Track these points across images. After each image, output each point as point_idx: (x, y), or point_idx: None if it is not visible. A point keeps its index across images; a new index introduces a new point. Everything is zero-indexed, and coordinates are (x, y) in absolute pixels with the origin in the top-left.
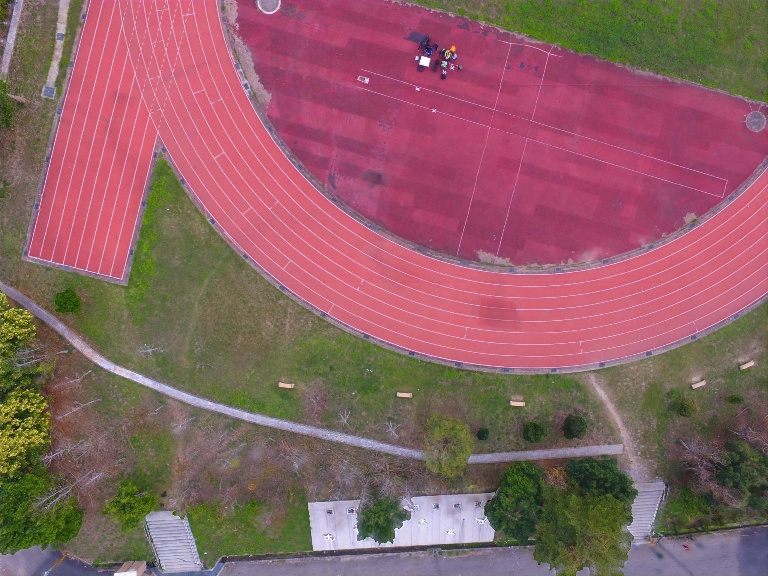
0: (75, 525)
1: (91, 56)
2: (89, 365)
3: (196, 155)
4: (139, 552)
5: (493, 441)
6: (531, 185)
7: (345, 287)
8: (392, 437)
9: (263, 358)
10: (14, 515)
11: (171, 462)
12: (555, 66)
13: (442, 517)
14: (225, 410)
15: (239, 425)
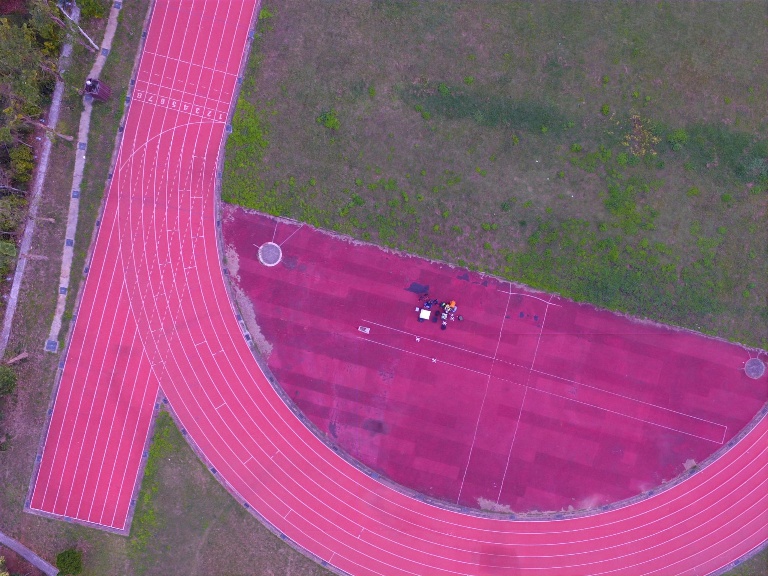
0: None
1: (94, 310)
2: None
3: (197, 406)
4: None
5: None
6: (531, 433)
7: (346, 535)
8: None
9: None
10: None
11: None
12: (554, 315)
13: None
14: None
15: None
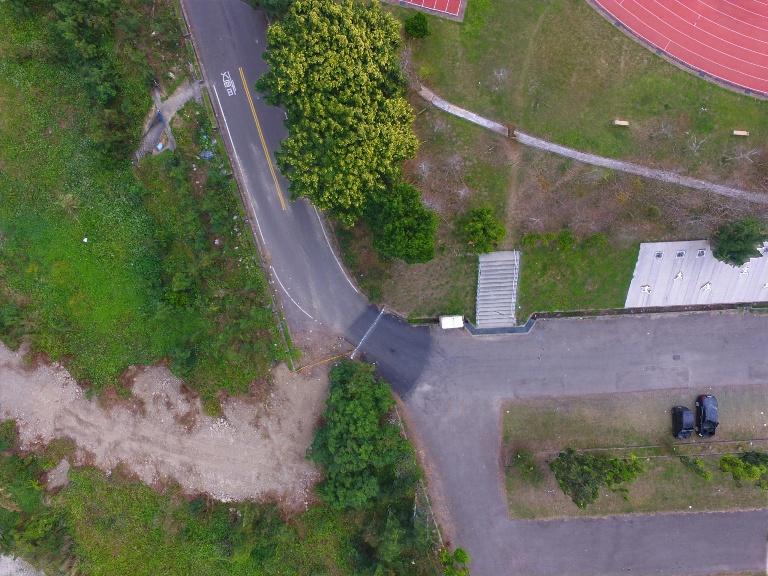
0: None
1: None
2: (423, 104)
3: None
4: (456, 305)
5: None
6: None
7: (682, 23)
8: (726, 178)
9: (597, 96)
10: (409, 208)
11: (504, 202)
12: None
13: (766, 265)
14: (559, 149)
15: (573, 165)
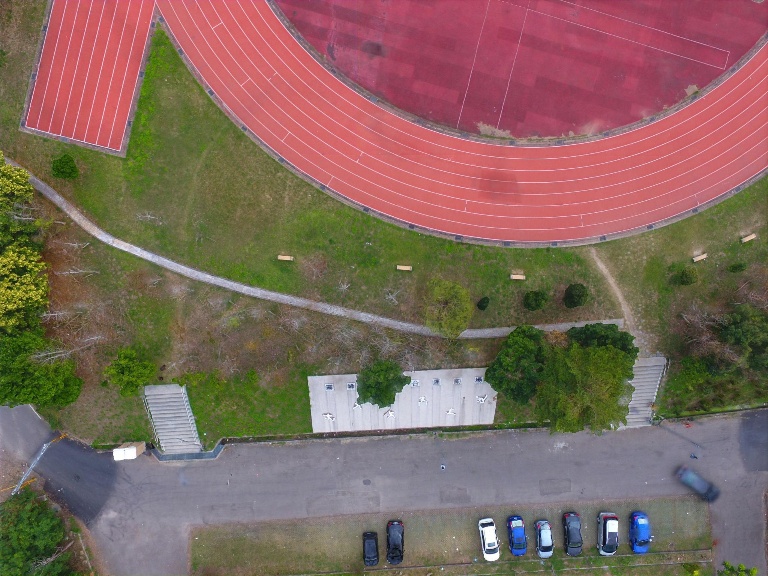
0: (74, 389)
1: None
2: (87, 238)
3: (194, 25)
4: (138, 432)
5: (493, 316)
6: (532, 56)
7: (344, 159)
8: (392, 311)
9: (262, 231)
10: (12, 365)
11: (170, 335)
12: None
13: (442, 395)
14: (224, 283)
15: (238, 298)
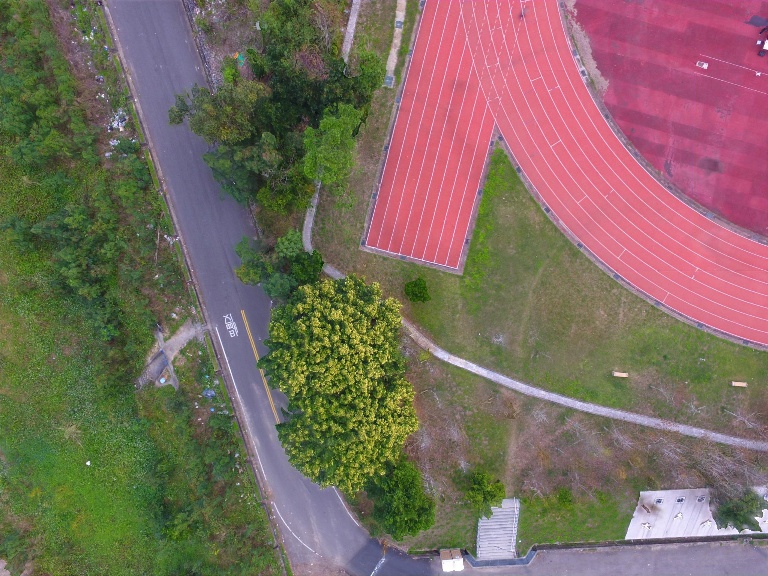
0: (433, 512)
1: (430, 44)
2: None
3: (533, 143)
4: (456, 540)
5: None
6: None
7: (680, 276)
8: (725, 426)
9: (596, 347)
10: (410, 502)
11: (504, 451)
12: None
13: None
14: (558, 399)
15: (572, 414)
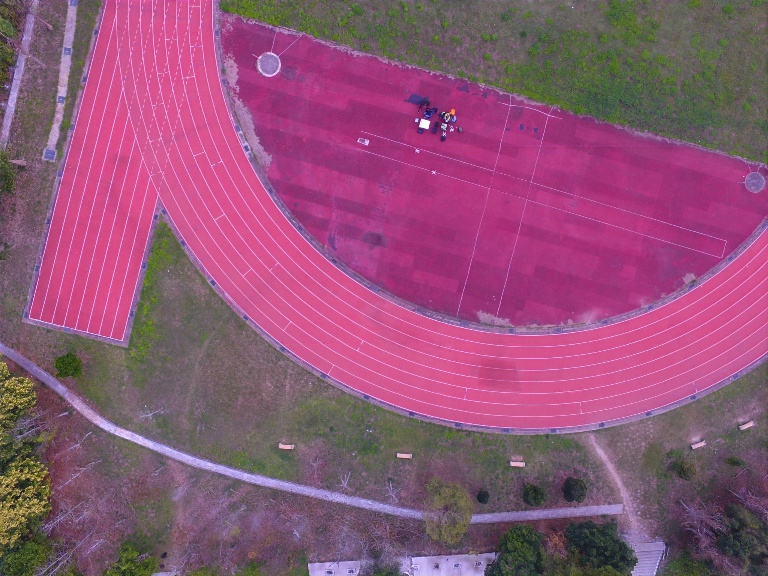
0: None
1: (92, 119)
2: (89, 426)
3: (196, 217)
4: None
5: (493, 501)
6: (531, 246)
7: (345, 348)
8: (392, 497)
9: (263, 419)
10: None
11: (171, 523)
12: (554, 128)
13: (442, 575)
14: (225, 471)
15: (239, 486)
